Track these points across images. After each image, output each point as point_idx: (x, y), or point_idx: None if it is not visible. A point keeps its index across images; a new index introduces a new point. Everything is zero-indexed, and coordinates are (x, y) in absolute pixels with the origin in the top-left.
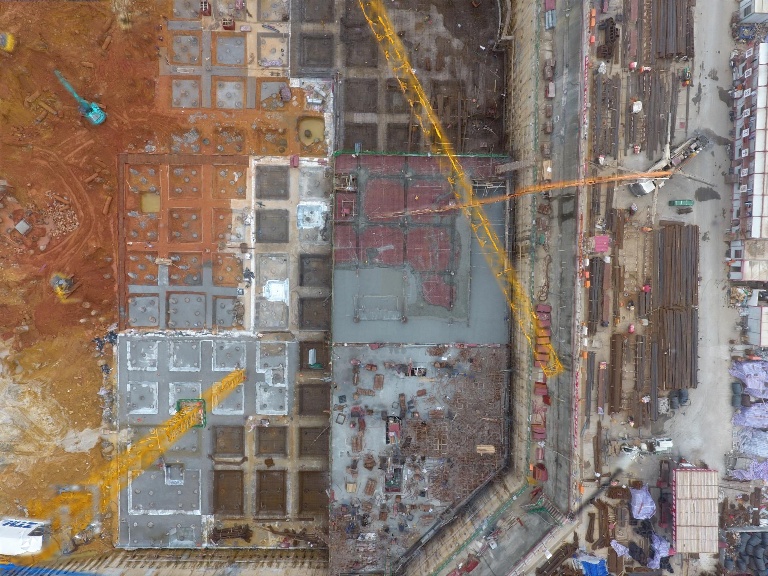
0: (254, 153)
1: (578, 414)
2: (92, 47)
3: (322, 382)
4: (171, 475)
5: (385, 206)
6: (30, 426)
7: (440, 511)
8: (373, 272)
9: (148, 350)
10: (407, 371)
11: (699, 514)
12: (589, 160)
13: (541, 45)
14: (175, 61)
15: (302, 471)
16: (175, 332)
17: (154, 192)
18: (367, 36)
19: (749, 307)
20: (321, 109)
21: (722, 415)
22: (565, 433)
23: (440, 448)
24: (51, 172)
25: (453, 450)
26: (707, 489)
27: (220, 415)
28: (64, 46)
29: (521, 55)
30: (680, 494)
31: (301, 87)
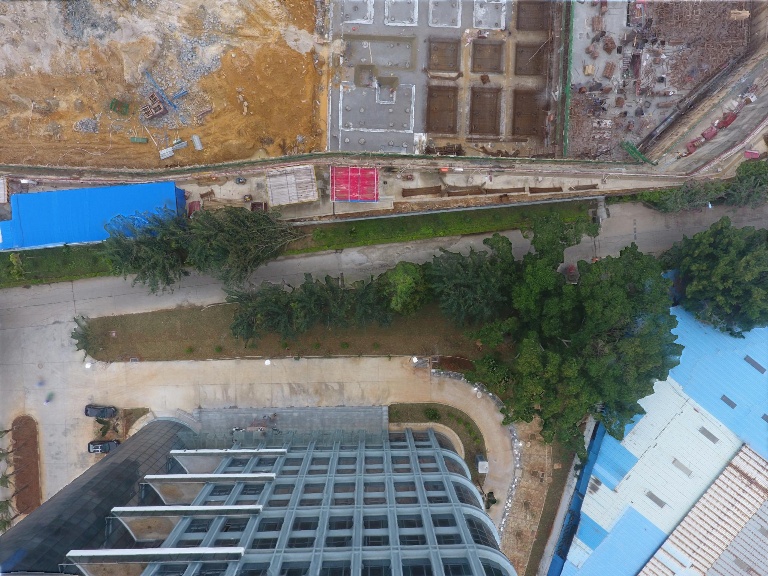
0: None
1: None
2: None
3: None
4: (381, 96)
5: None
6: (255, 8)
7: (677, 100)
8: None
9: None
10: None
11: None
12: None
13: None
14: None
15: (517, 91)
16: None
17: None
18: None
19: None
20: None
21: None
22: None
23: (692, 13)
24: None
25: (693, 35)
26: None
27: (436, 27)
28: None
29: None
30: None
31: None
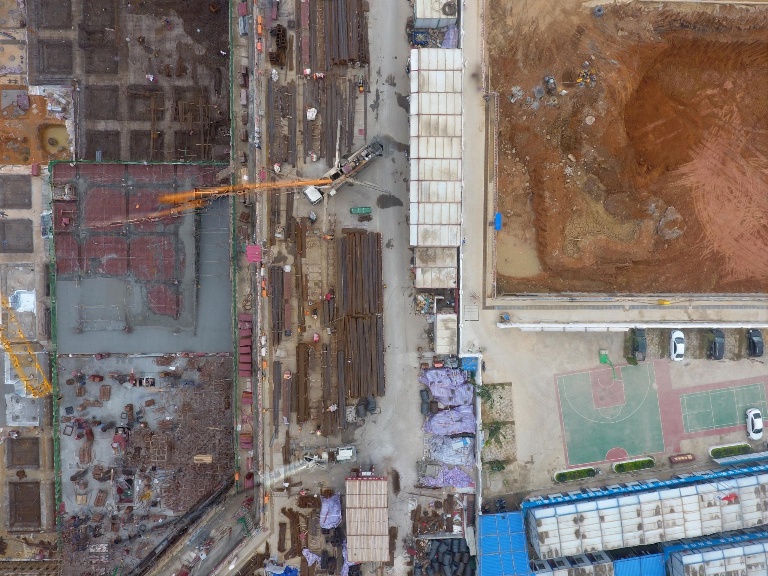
0: None
1: (266, 424)
2: None
3: None
4: None
5: (106, 215)
6: None
7: (173, 521)
8: (96, 282)
9: None
10: None
11: (369, 523)
12: (267, 168)
13: (237, 51)
14: None
15: None
16: None
17: None
18: (107, 42)
19: (434, 314)
20: (61, 117)
21: (413, 422)
22: None
23: (159, 459)
24: None
25: (184, 460)
26: (376, 498)
27: None
28: None
29: None
30: (349, 503)
31: (41, 94)
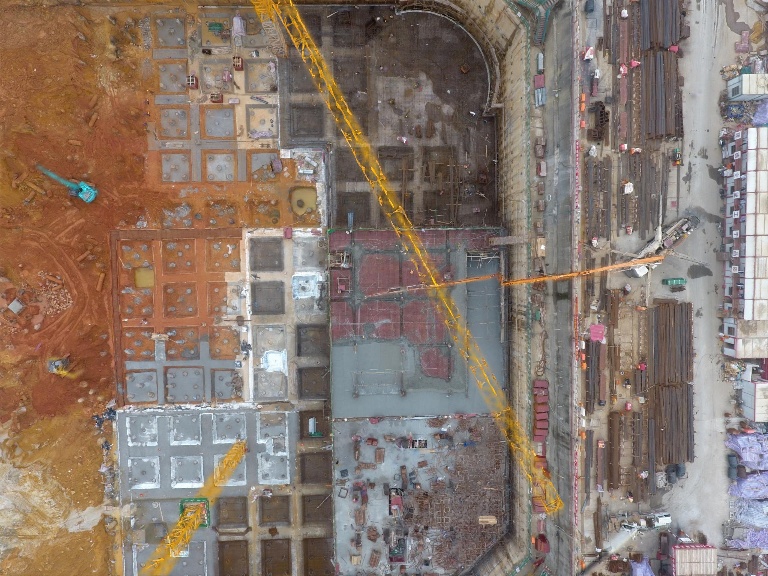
0: (247, 225)
1: (578, 491)
2: (79, 124)
3: (323, 450)
4: None
5: (380, 281)
6: (32, 510)
7: None
8: (371, 347)
9: (148, 425)
10: (408, 446)
11: None
12: (582, 242)
13: (531, 122)
14: (163, 135)
15: (306, 538)
16: (174, 406)
17: (147, 267)
18: (356, 104)
19: (743, 381)
20: (313, 179)
21: (719, 486)
22: (566, 510)
23: (443, 521)
24: (42, 253)
25: (455, 519)
26: (706, 566)
27: (222, 487)
28: (50, 126)
29: (511, 126)
30: (680, 571)
31: (292, 157)
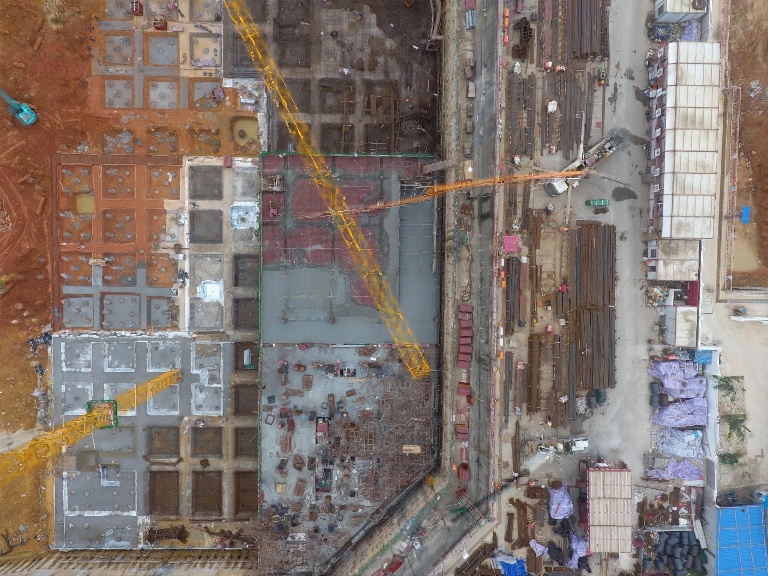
0: (187, 153)
1: (496, 414)
2: (24, 47)
3: (257, 382)
4: (107, 476)
5: (313, 206)
6: None
7: (370, 511)
8: (301, 272)
9: (83, 351)
10: (334, 371)
11: (612, 514)
12: (505, 160)
13: (462, 45)
14: (108, 61)
15: (238, 472)
16: (109, 333)
17: (88, 193)
18: (300, 36)
19: (666, 307)
20: (254, 109)
21: (641, 415)
22: (484, 433)
23: (366, 448)
24: None
25: (383, 450)
26: (620, 489)
27: (155, 416)
28: None
29: (448, 55)
30: (593, 494)
31: (234, 87)
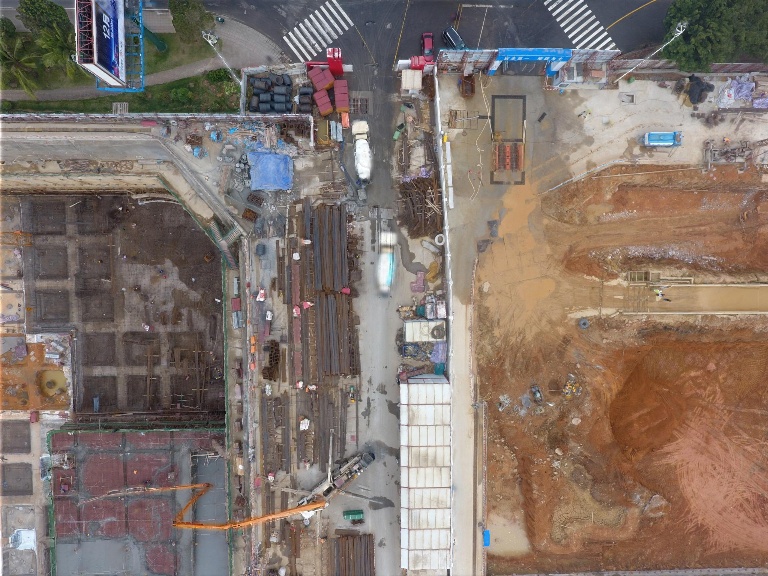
0: None
1: None
2: None
3: None
4: None
5: (105, 480)
6: None
7: None
8: (95, 545)
9: None
10: None
11: None
12: (262, 475)
13: (231, 343)
14: None
15: None
16: None
17: None
18: (103, 290)
19: None
20: (59, 364)
21: None
22: None
23: None
24: None
25: None
26: None
27: None
28: None
29: None
30: None
31: (39, 341)
